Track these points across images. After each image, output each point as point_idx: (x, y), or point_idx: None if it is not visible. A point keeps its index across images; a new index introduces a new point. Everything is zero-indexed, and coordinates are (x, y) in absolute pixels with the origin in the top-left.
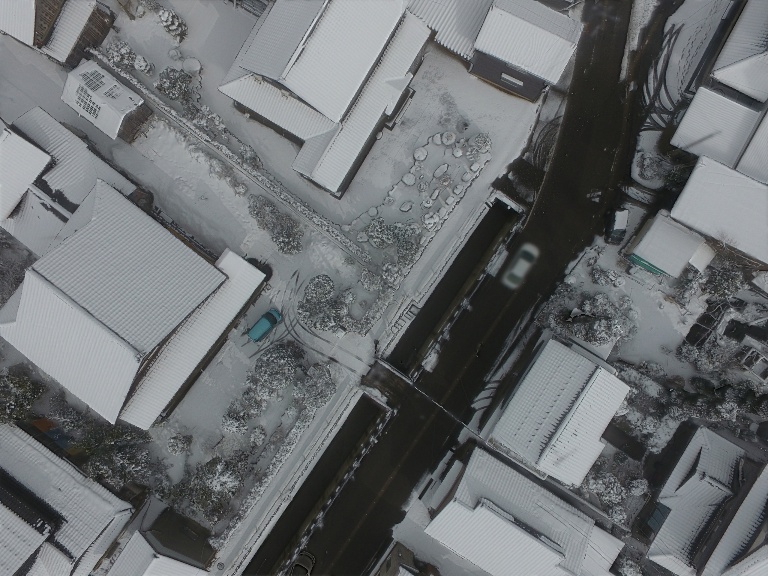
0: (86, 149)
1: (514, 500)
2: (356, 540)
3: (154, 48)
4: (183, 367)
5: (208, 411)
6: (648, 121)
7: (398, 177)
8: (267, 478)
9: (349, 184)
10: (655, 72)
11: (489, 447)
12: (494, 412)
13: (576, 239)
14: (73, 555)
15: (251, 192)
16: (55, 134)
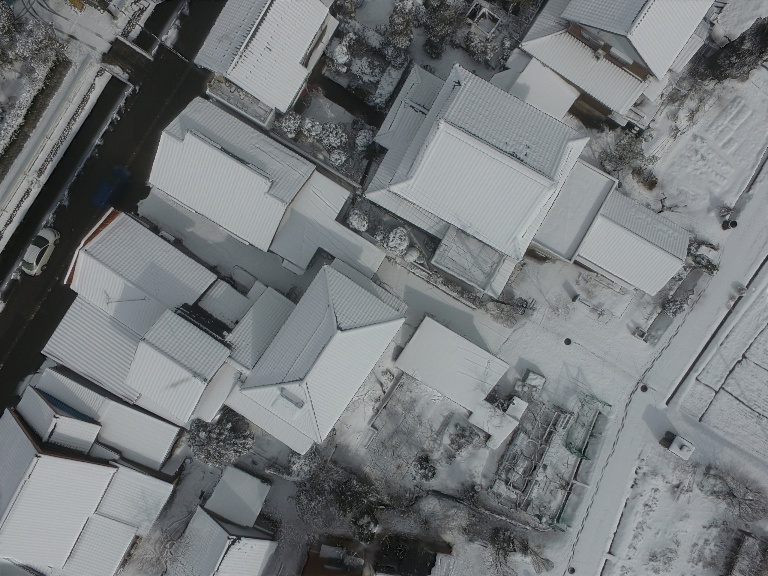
0: None
1: (230, 139)
2: None
3: None
4: None
5: None
6: None
7: None
8: None
9: None
10: None
11: (216, 102)
12: None
13: None
14: None
15: None
16: None
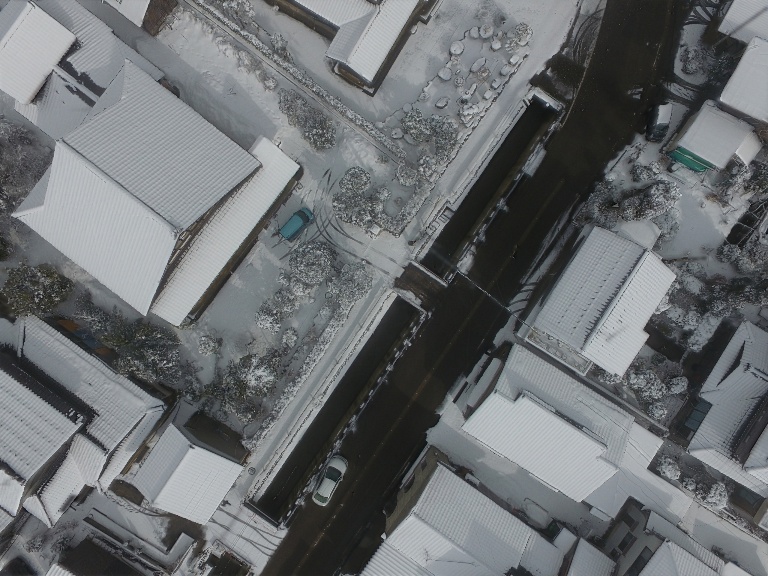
0: (111, 33)
1: (554, 394)
2: (389, 444)
3: None
4: (215, 260)
5: (238, 314)
6: (692, 14)
7: (433, 73)
8: (300, 378)
9: (382, 80)
10: None
11: (527, 345)
12: (533, 309)
13: (616, 137)
14: (106, 447)
15: (281, 87)
16: (79, 17)
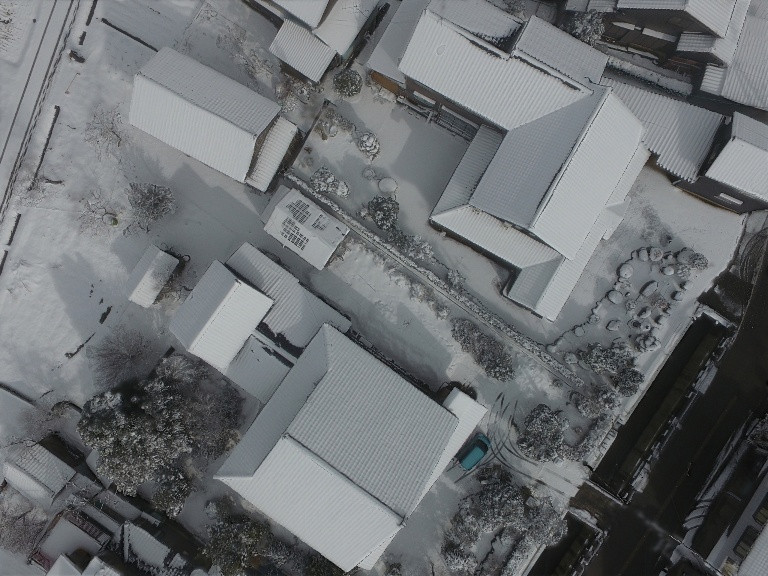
0: (299, 285)
1: None
2: None
3: (347, 168)
4: None
5: (414, 538)
6: None
7: (601, 294)
8: None
9: None
10: None
11: (715, 574)
12: (720, 539)
13: None
14: None
15: (453, 314)
16: (268, 271)
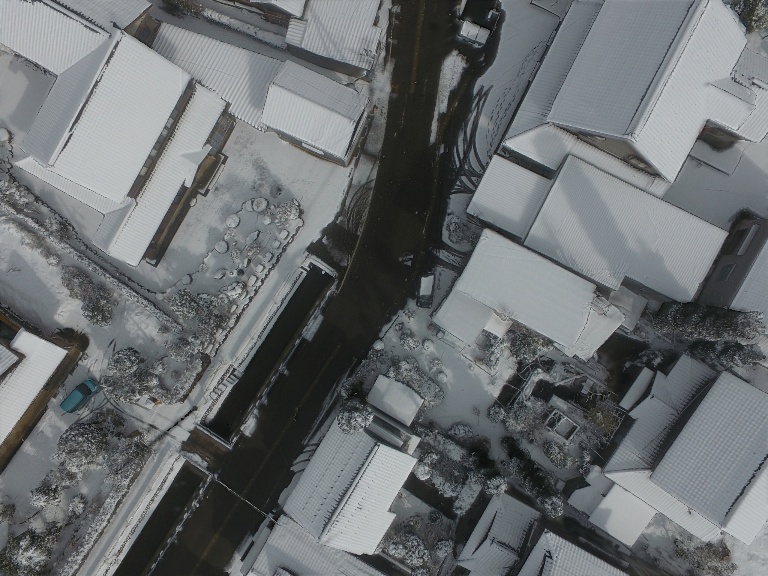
0: None
1: (315, 567)
2: None
3: None
4: None
5: (30, 480)
6: (458, 184)
7: (213, 243)
8: (83, 548)
9: (165, 251)
10: (465, 134)
11: None
12: None
13: (389, 302)
14: None
15: (65, 262)
16: None
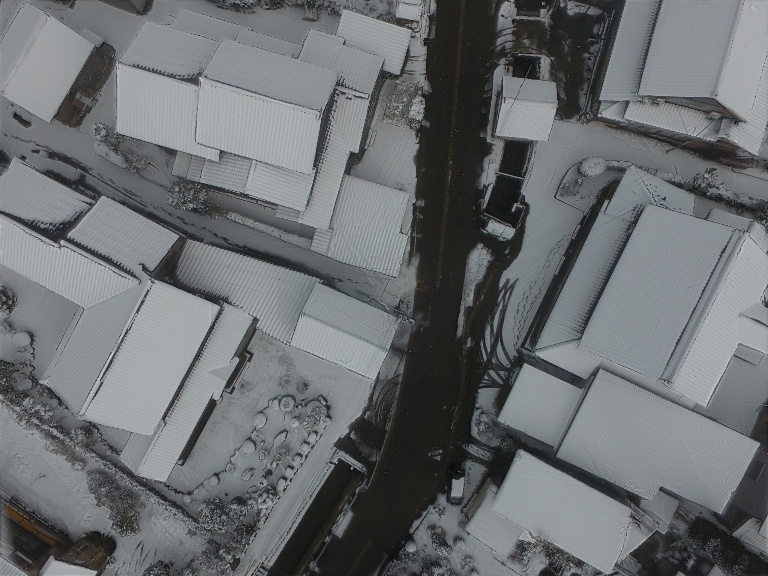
0: None
1: None
2: None
3: None
4: None
5: None
6: (486, 378)
7: (240, 441)
8: None
9: (191, 450)
10: (491, 327)
11: None
12: None
13: (419, 498)
14: None
15: (90, 466)
16: None
